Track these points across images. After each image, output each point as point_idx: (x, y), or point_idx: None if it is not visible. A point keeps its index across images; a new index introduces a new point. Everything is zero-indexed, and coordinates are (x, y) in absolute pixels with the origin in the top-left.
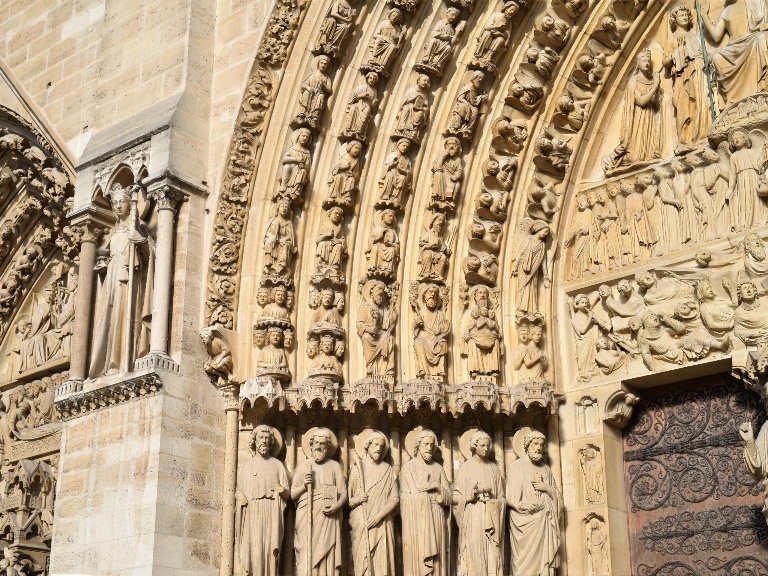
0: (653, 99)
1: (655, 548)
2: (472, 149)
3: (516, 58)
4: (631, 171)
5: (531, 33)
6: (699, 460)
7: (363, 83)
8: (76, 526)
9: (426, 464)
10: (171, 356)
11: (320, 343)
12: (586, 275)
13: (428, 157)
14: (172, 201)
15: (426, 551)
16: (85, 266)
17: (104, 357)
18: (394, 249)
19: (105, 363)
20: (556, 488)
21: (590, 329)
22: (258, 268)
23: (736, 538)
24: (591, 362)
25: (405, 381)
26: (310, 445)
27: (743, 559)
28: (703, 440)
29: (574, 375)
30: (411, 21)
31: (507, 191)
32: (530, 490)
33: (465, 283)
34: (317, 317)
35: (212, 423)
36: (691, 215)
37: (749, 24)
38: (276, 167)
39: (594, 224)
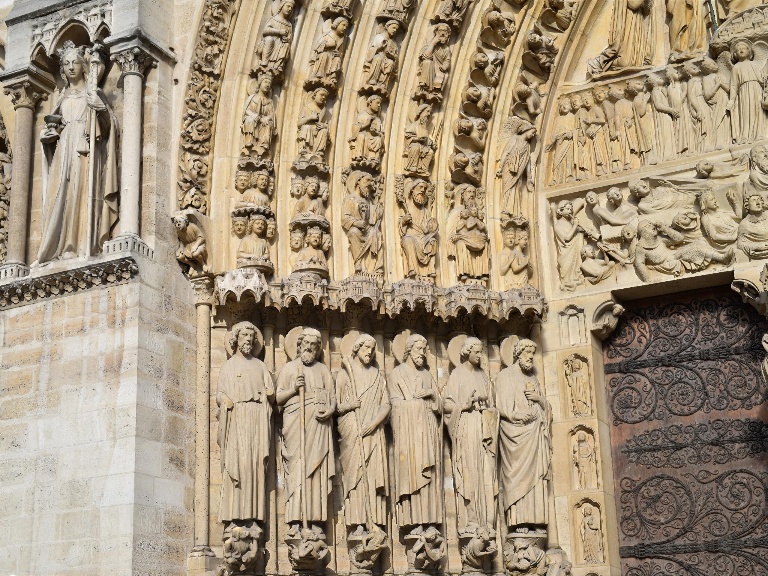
0: (642, 4)
1: (640, 461)
2: (460, 39)
3: None
4: (620, 76)
5: None
6: (687, 373)
7: None
8: (24, 429)
9: (417, 370)
10: (143, 240)
11: (307, 235)
12: (570, 181)
13: (415, 43)
14: (141, 66)
15: (425, 461)
16: (22, 134)
17: (57, 238)
18: (381, 139)
19: (59, 245)
20: (545, 399)
21: (574, 237)
22: (235, 149)
23: (729, 451)
24: (576, 271)
25: (392, 281)
26: (297, 345)
27: (736, 472)
28: (692, 353)
29: (555, 284)
30: None
31: (493, 87)
32: (523, 400)
33: (450, 181)
34: (301, 207)
35: (184, 318)
36: (688, 125)
37: None
38: (254, 38)
39: (579, 129)
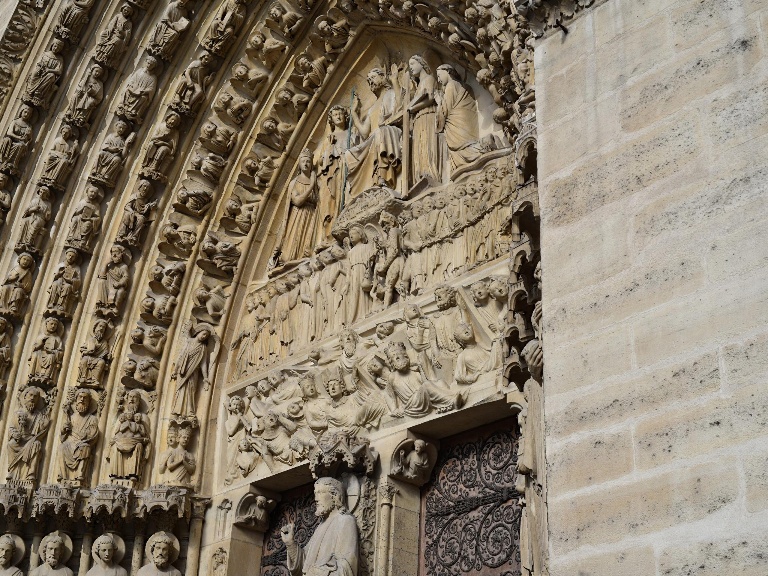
0: (314, 198)
1: None
2: (142, 256)
3: (185, 165)
4: (286, 271)
5: (199, 141)
6: None
7: (37, 197)
8: None
9: (52, 569)
10: None
11: None
12: (242, 376)
13: (99, 265)
14: None
15: None
16: None
17: None
18: (53, 356)
19: None
20: None
21: (239, 431)
22: None
23: None
24: (234, 464)
25: None
26: None
27: None
28: None
29: None
30: (87, 136)
31: (173, 295)
32: None
33: (124, 388)
34: None
35: None
36: (319, 313)
37: (379, 119)
38: None
39: None
